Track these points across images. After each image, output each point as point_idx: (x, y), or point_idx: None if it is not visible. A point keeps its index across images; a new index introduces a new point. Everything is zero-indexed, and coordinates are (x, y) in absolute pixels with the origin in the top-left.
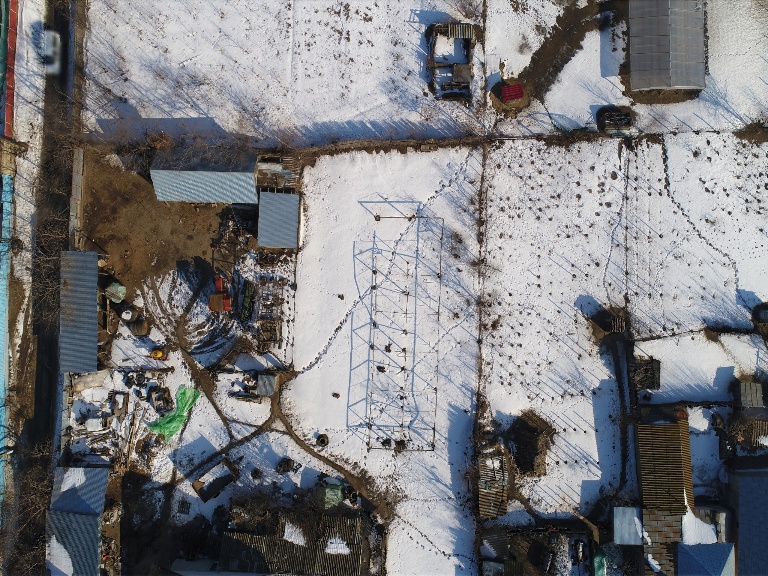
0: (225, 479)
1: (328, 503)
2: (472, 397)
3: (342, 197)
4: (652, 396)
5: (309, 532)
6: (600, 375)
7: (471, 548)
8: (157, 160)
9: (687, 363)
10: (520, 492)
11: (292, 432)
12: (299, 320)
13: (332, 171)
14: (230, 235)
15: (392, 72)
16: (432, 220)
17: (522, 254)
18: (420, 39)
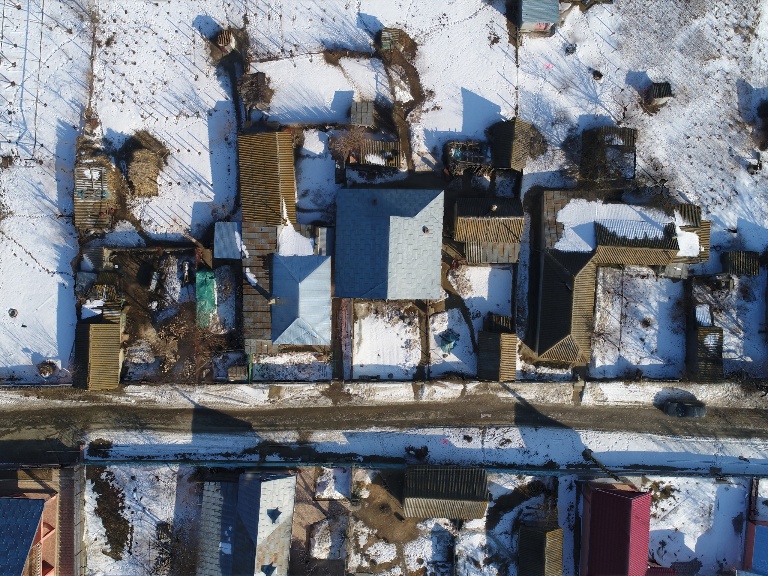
0: None
1: None
2: (82, 113)
3: None
4: (269, 118)
5: None
6: (216, 96)
7: None
8: None
9: (304, 85)
10: (131, 213)
11: None
12: None
13: None
14: None
15: None
16: None
17: None
18: None
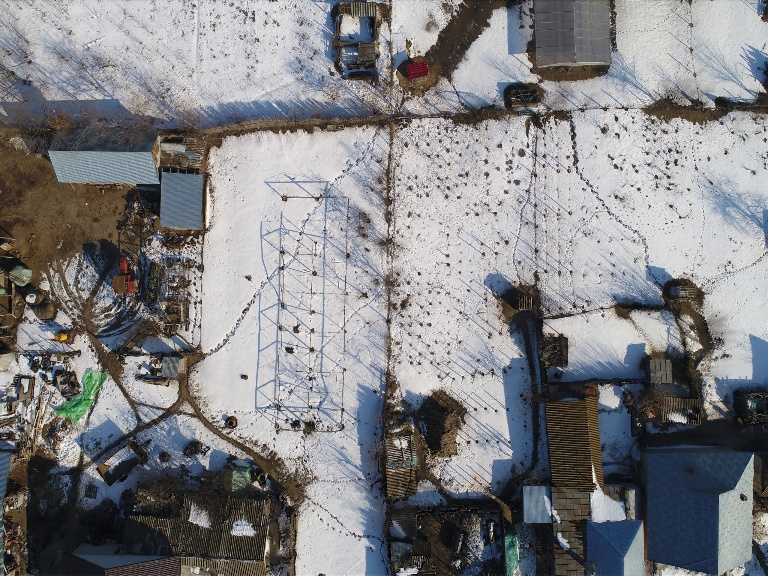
0: (131, 462)
1: (235, 485)
2: (381, 377)
3: (248, 178)
4: (563, 374)
5: (215, 514)
6: (510, 354)
7: (381, 529)
8: (55, 141)
9: (597, 340)
10: (431, 472)
11: (200, 414)
12: (206, 302)
13: (238, 152)
14: (136, 217)
15: (298, 52)
16: (339, 200)
17: (431, 233)
18: (326, 18)
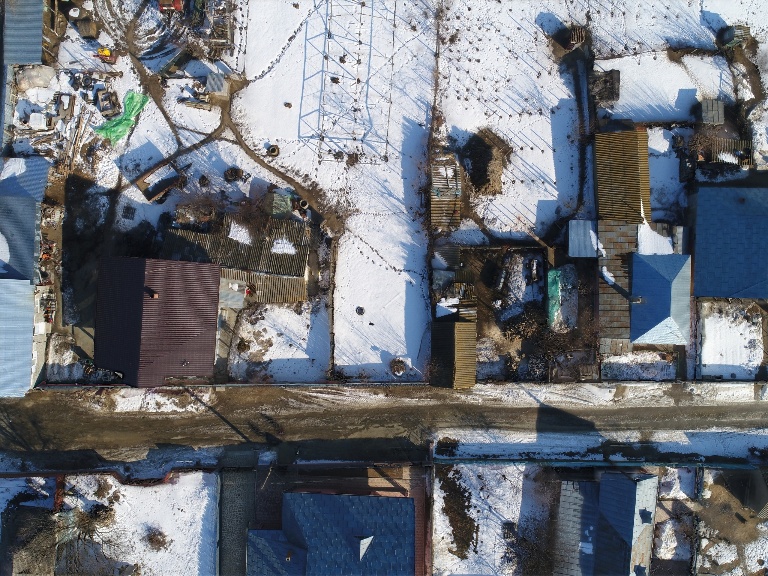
0: (171, 180)
1: (276, 208)
2: (427, 111)
3: None
4: (612, 116)
5: (255, 233)
6: (559, 94)
7: (422, 263)
8: None
9: (648, 83)
10: (475, 211)
11: (242, 142)
12: (252, 28)
13: None
14: None
15: None
16: None
17: None
18: None
